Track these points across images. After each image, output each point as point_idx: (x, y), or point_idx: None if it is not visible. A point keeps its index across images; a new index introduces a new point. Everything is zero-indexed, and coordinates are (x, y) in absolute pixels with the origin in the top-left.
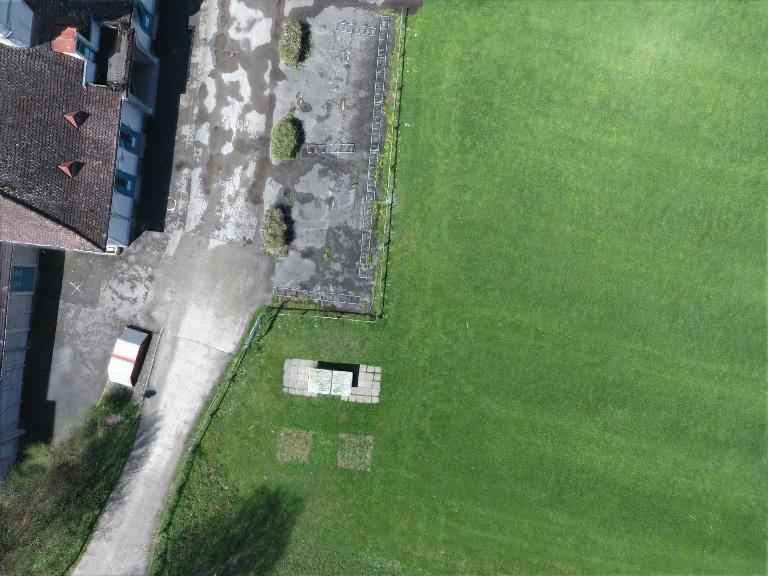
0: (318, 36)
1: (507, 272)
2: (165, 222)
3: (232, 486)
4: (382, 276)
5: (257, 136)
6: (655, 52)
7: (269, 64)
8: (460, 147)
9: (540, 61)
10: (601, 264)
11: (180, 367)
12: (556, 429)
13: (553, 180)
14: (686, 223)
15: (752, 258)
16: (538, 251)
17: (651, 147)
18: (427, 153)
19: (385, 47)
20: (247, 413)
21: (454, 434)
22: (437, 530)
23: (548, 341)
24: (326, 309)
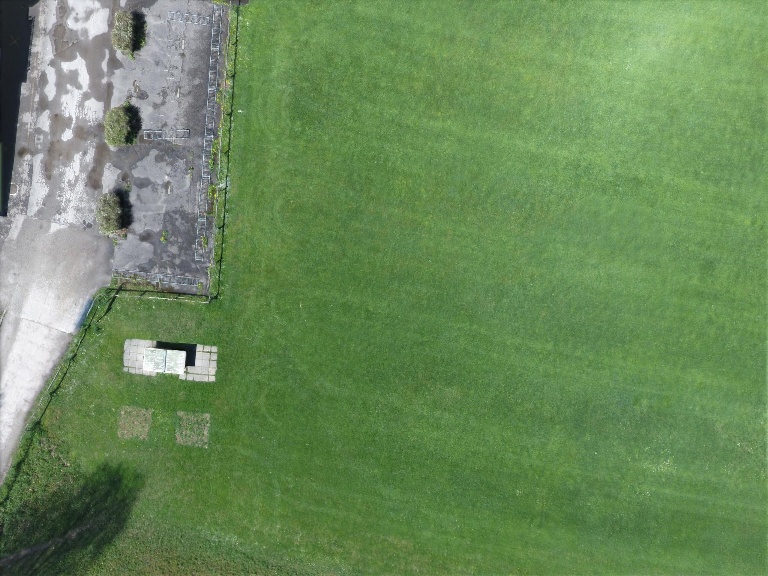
0: (153, 25)
1: (338, 254)
2: (8, 207)
3: (74, 462)
4: (217, 258)
5: (96, 123)
6: (478, 39)
7: (106, 53)
8: (291, 132)
9: (367, 48)
10: (428, 245)
11: (21, 347)
12: (387, 406)
13: (381, 164)
14: (510, 205)
15: (574, 239)
16: (367, 233)
17: (475, 131)
18: (259, 138)
19: (218, 36)
20: (88, 392)
21: (289, 412)
22: (273, 505)
23: (378, 321)
24: (164, 290)
